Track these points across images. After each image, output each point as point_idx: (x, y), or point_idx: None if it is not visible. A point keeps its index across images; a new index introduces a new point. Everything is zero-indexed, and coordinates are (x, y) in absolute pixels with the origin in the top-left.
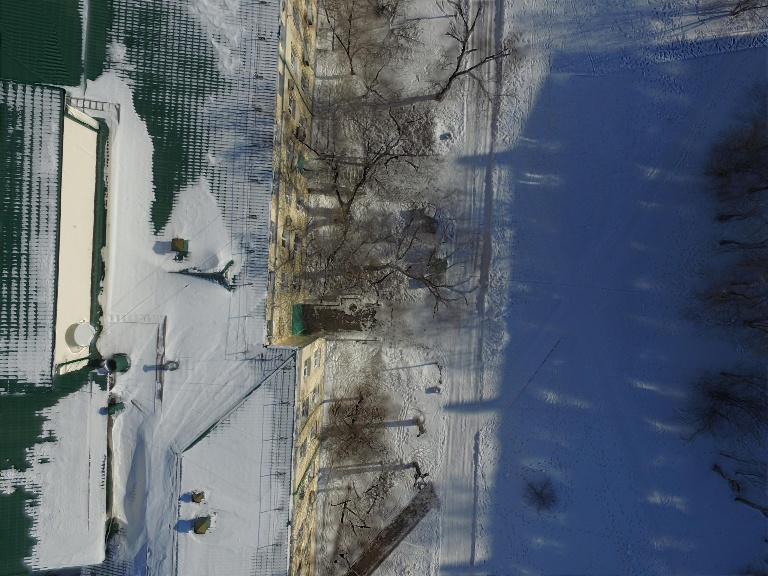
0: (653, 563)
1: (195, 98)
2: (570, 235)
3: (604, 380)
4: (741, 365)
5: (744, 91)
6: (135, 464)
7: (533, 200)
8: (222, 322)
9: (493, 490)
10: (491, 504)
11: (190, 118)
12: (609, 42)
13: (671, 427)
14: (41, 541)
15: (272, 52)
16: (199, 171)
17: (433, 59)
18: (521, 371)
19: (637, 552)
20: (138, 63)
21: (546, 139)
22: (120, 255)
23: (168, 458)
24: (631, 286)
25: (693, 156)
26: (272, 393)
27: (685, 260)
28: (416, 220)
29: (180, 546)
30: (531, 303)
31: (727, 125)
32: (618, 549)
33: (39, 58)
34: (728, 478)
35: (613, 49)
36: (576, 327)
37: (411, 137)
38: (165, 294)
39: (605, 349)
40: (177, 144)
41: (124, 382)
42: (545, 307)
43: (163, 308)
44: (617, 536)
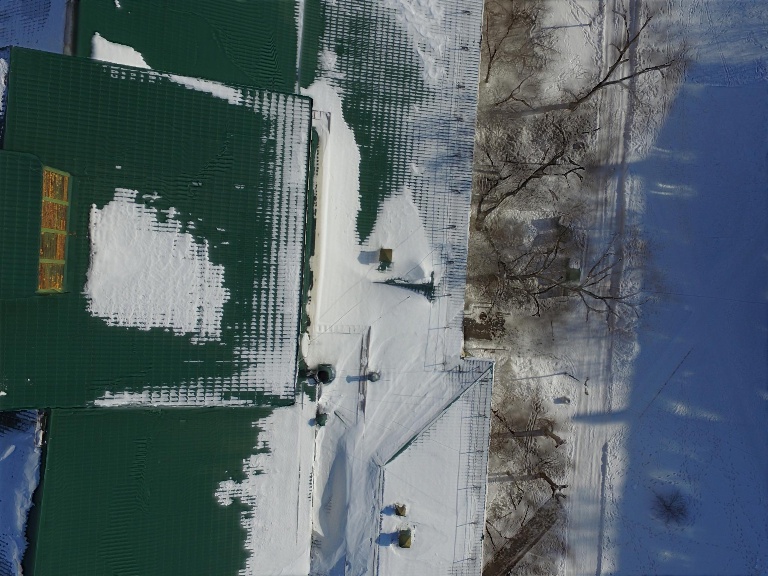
0: None
1: (401, 107)
2: (702, 246)
3: (734, 392)
4: None
5: None
6: (333, 476)
7: (665, 210)
8: (422, 333)
9: (620, 502)
10: (618, 516)
11: (395, 127)
12: (745, 53)
13: None
14: (254, 554)
15: (474, 62)
16: (403, 181)
17: (567, 68)
18: (650, 382)
19: (765, 566)
20: (347, 71)
21: (679, 149)
22: (329, 265)
23: (370, 470)
24: (763, 298)
25: None
26: (470, 405)
27: None
28: (547, 229)
29: (381, 560)
30: (662, 314)
31: None
32: (746, 563)
33: (255, 65)
34: None
35: (749, 60)
36: (707, 339)
37: (544, 146)
38: (370, 304)
39: (736, 361)
40: (382, 153)
41: (329, 393)
42: (676, 318)
43: (367, 318)
44: (745, 550)
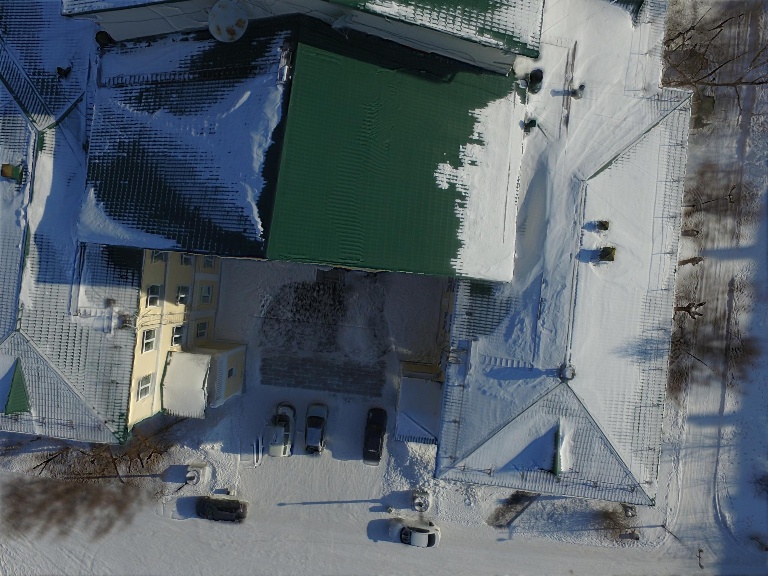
0: None
1: None
2: None
3: None
4: None
5: None
6: (529, 195)
7: None
8: (624, 56)
9: (746, 339)
10: (743, 353)
11: None
12: None
13: None
14: (465, 245)
15: None
16: None
17: None
18: None
19: None
20: None
21: None
22: None
23: (572, 185)
24: None
25: None
26: (668, 133)
27: None
28: None
29: (580, 276)
30: None
31: None
32: None
33: None
34: None
35: None
36: None
37: None
38: (576, 19)
39: None
40: None
41: (534, 103)
42: None
43: (574, 33)
44: None
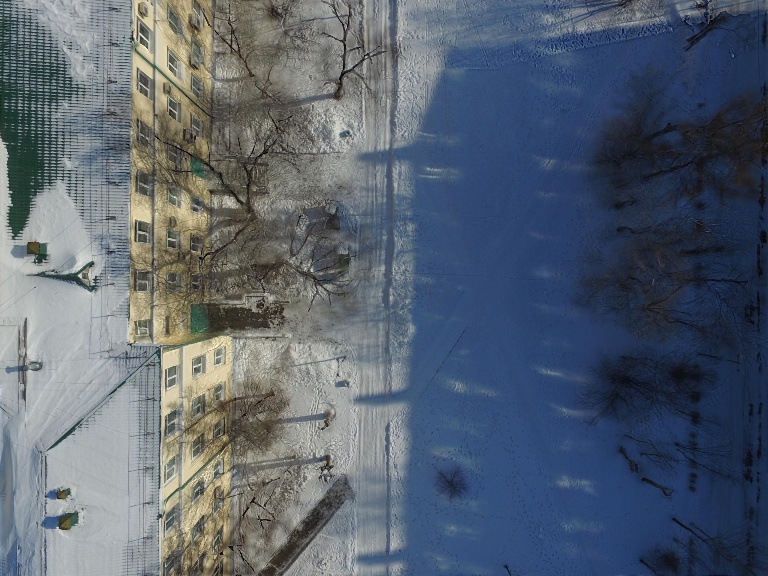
0: (565, 545)
1: (48, 104)
2: (471, 226)
3: (510, 368)
4: (638, 348)
5: (635, 79)
6: (4, 464)
7: (434, 193)
8: (84, 322)
9: (406, 480)
10: (404, 494)
11: (44, 124)
12: (501, 36)
13: (577, 411)
14: None
15: (125, 57)
16: (55, 175)
17: (330, 58)
18: (428, 362)
19: (549, 535)
20: None
21: (444, 133)
22: None
23: (33, 457)
24: (532, 274)
25: (588, 145)
26: (137, 390)
27: (584, 247)
28: (320, 217)
29: (48, 542)
30: (435, 295)
31: (619, 113)
32: (530, 533)
33: None
34: (632, 459)
35: (505, 43)
36: (480, 317)
37: (311, 136)
38: (25, 296)
39: (509, 337)
40: (32, 150)
41: None
42: (449, 298)
43: (23, 310)
44: (529, 520)
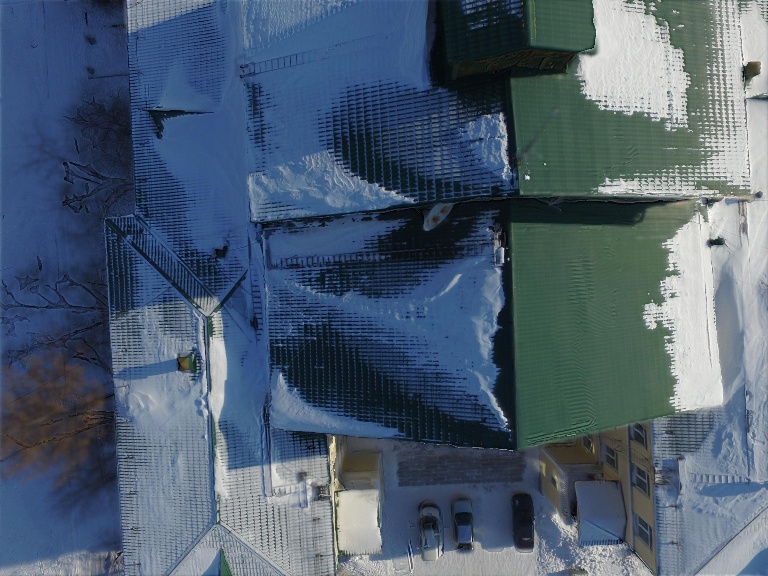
0: None
1: None
2: None
3: None
4: None
5: None
6: (716, 306)
7: None
8: None
9: None
10: None
11: None
12: None
13: None
14: (679, 380)
15: None
16: None
17: None
18: None
19: None
20: None
21: None
22: None
23: (762, 292)
24: None
25: None
26: None
27: None
28: None
29: None
30: None
31: None
32: None
33: None
34: None
35: None
36: None
37: None
38: None
39: None
40: None
41: (712, 216)
42: None
43: None
44: None
